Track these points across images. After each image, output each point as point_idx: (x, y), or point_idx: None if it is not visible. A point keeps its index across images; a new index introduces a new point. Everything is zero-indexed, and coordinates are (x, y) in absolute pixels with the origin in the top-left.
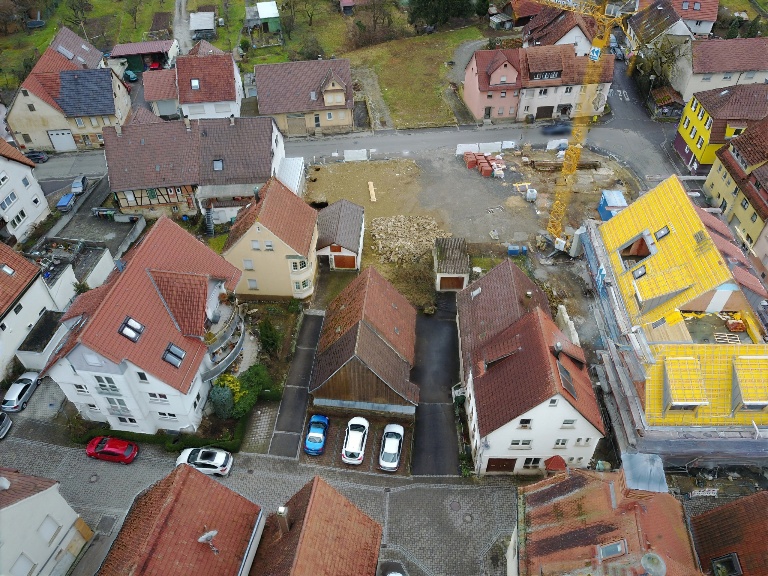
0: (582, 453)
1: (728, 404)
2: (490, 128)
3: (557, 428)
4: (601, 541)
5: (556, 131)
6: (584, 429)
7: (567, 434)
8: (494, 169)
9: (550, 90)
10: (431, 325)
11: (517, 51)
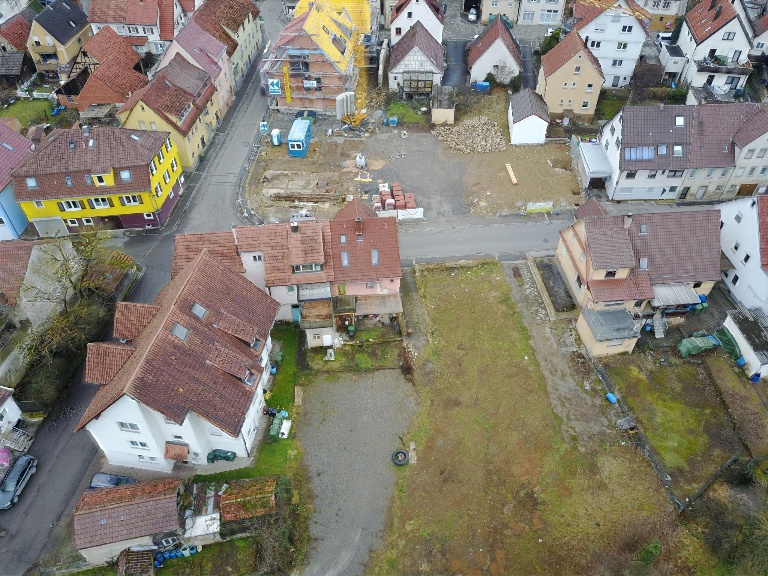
0: None
1: None
2: None
3: None
4: None
5: None
6: None
7: None
8: None
9: None
10: None
11: None
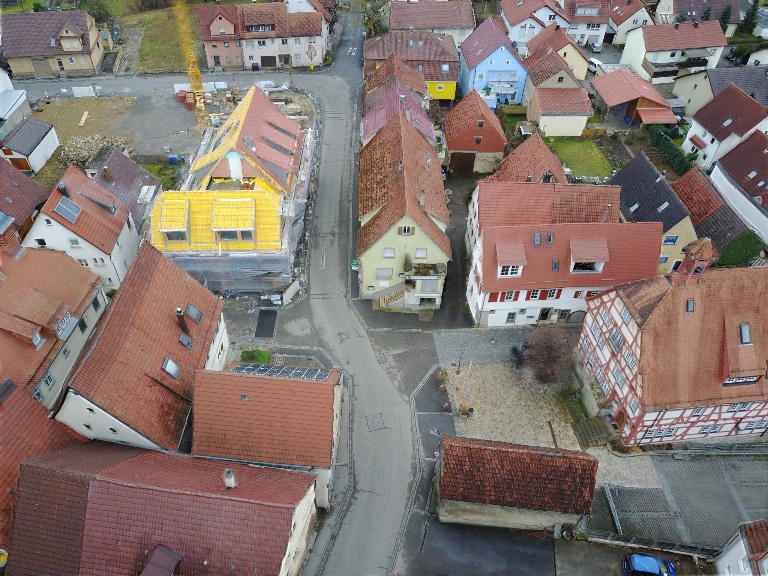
0: (107, 274)
1: (214, 235)
2: (219, 74)
3: (68, 248)
4: None
5: (275, 77)
6: (89, 248)
7: (80, 254)
8: (196, 102)
9: (267, 41)
10: None
11: (235, 7)
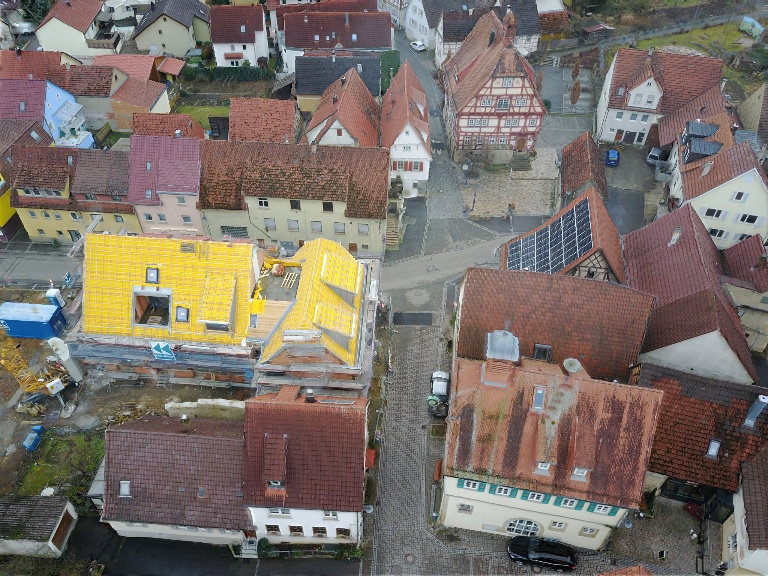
0: None
1: (347, 306)
2: None
3: None
4: (528, 406)
5: None
6: None
7: None
8: None
9: None
10: (122, 573)
11: None
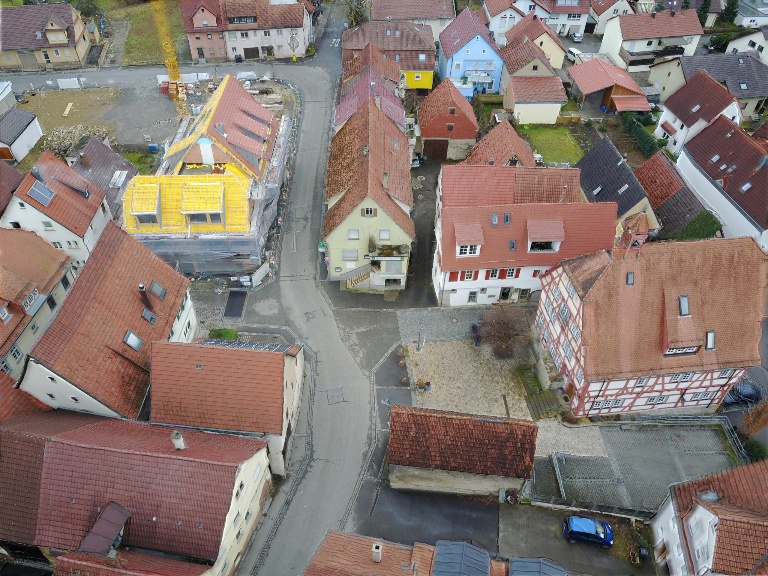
0: (81, 256)
1: (184, 218)
2: (203, 66)
3: (42, 230)
4: None
5: (257, 68)
6: (62, 231)
7: (54, 236)
8: (179, 93)
9: (250, 33)
10: None
11: None
